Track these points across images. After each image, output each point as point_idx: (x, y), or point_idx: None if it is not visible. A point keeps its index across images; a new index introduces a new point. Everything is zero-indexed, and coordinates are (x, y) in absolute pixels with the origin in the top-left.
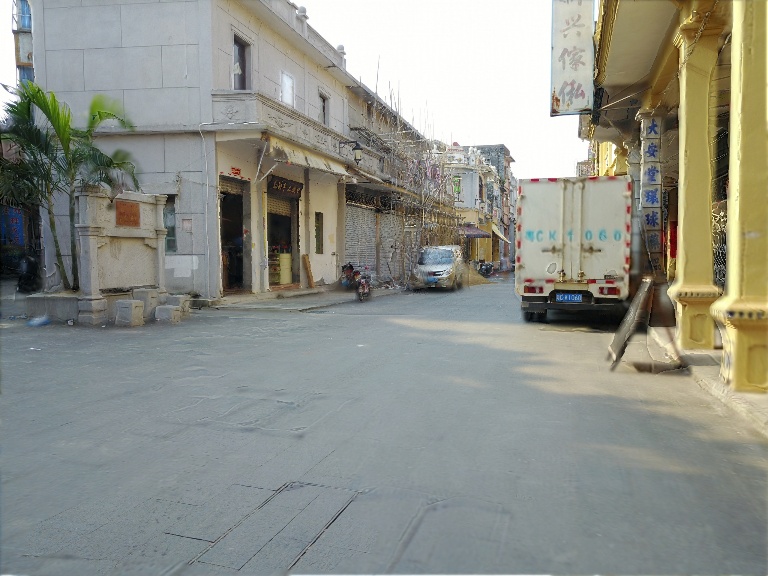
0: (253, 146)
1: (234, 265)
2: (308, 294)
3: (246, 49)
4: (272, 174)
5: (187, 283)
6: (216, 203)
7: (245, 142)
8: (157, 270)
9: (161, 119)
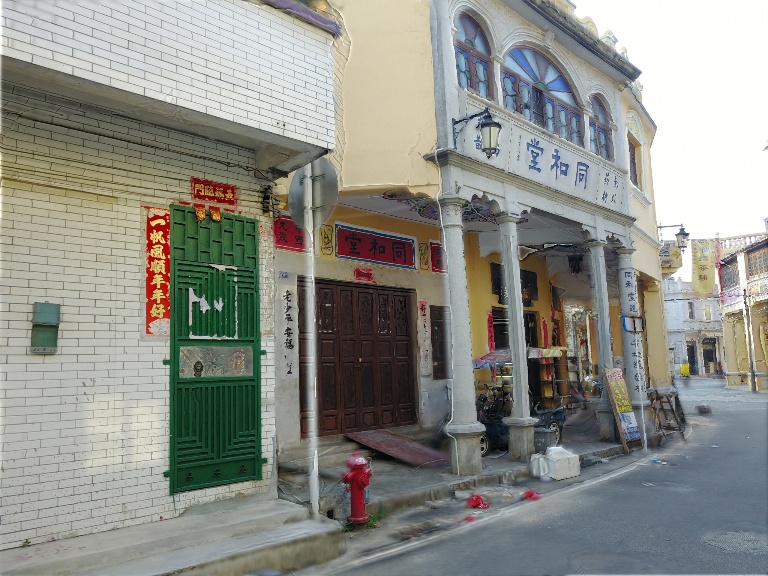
0: (696, 333)
1: (692, 366)
2: (720, 376)
3: (692, 304)
4: (704, 338)
5: (679, 371)
6: (686, 350)
7: (694, 332)
8: (673, 368)
9: (669, 328)
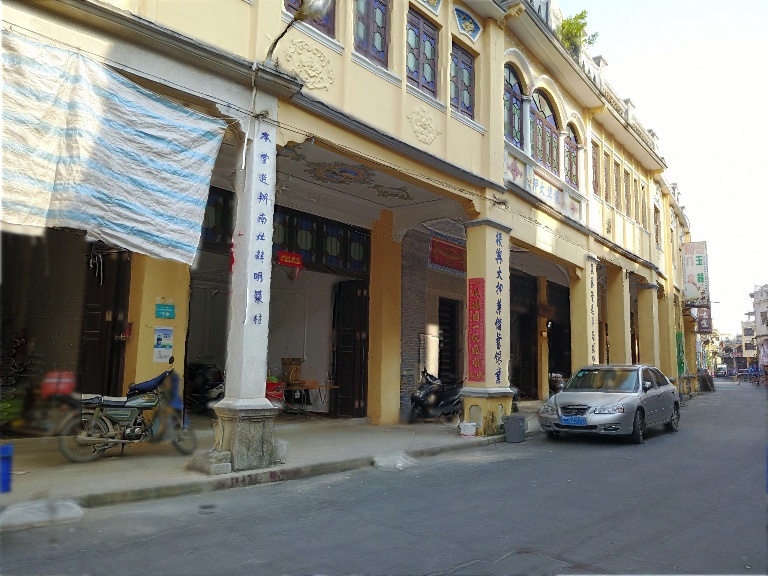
0: None
1: None
2: None
3: None
4: None
5: None
6: None
7: None
8: None
9: None
